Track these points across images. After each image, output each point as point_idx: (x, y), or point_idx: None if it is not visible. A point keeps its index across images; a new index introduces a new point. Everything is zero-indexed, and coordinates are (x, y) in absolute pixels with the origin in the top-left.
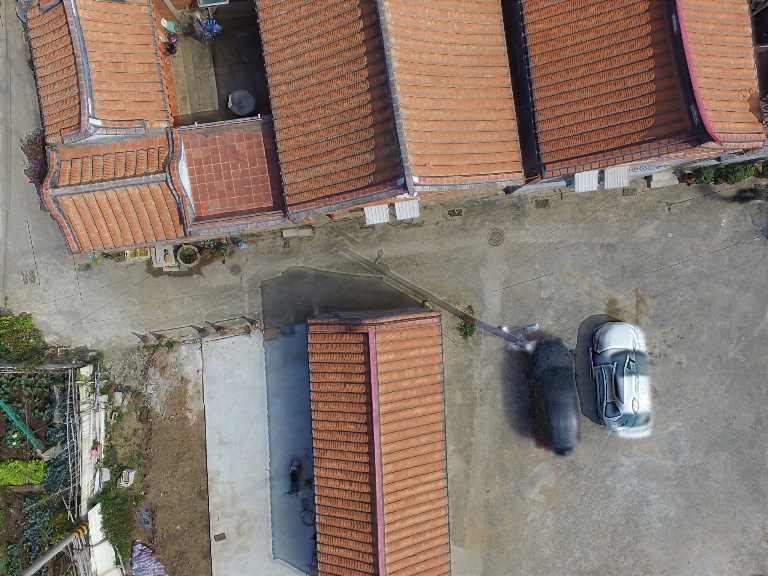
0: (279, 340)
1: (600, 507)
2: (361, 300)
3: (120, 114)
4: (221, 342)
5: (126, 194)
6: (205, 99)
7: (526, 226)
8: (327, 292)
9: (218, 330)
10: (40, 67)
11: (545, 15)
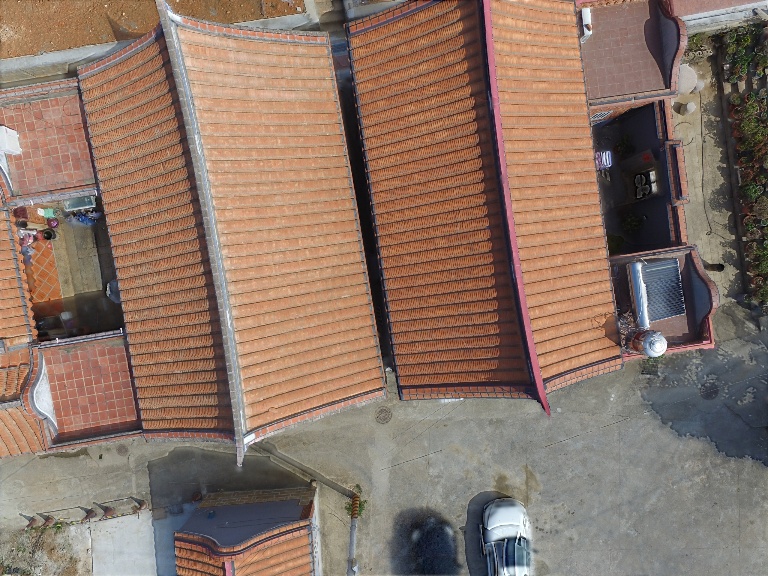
0: (168, 519)
1: None
2: (249, 479)
3: None
4: (110, 522)
5: None
6: (89, 279)
7: (413, 403)
8: (215, 471)
9: (103, 515)
10: None
11: (397, 241)
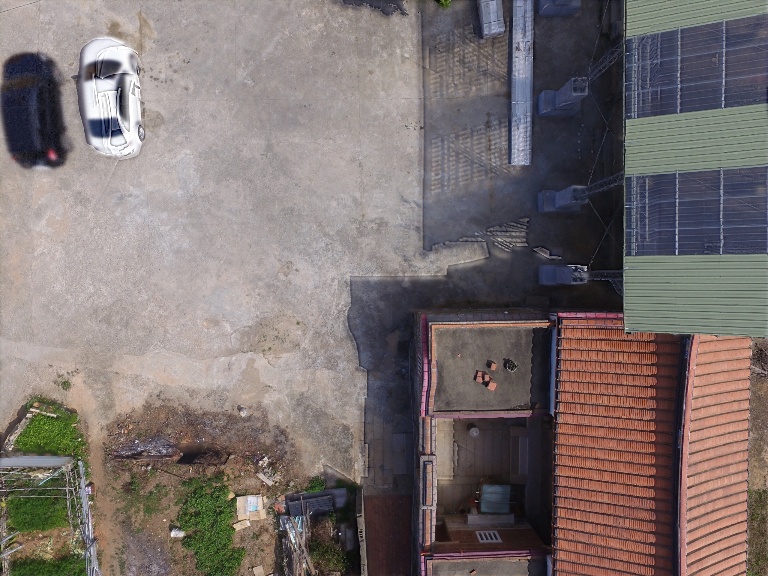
0: None
1: (111, 240)
2: None
3: None
4: None
5: None
6: None
7: None
8: None
9: None
10: None
11: None
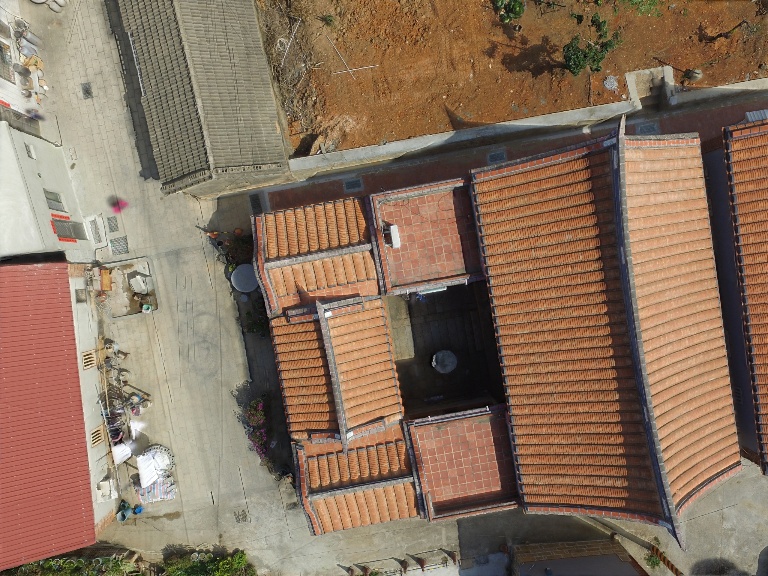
0: (474, 568)
1: None
2: (552, 532)
3: (365, 417)
4: (420, 571)
5: (371, 490)
6: (402, 348)
7: None
8: (520, 525)
9: (422, 567)
10: (285, 370)
11: None
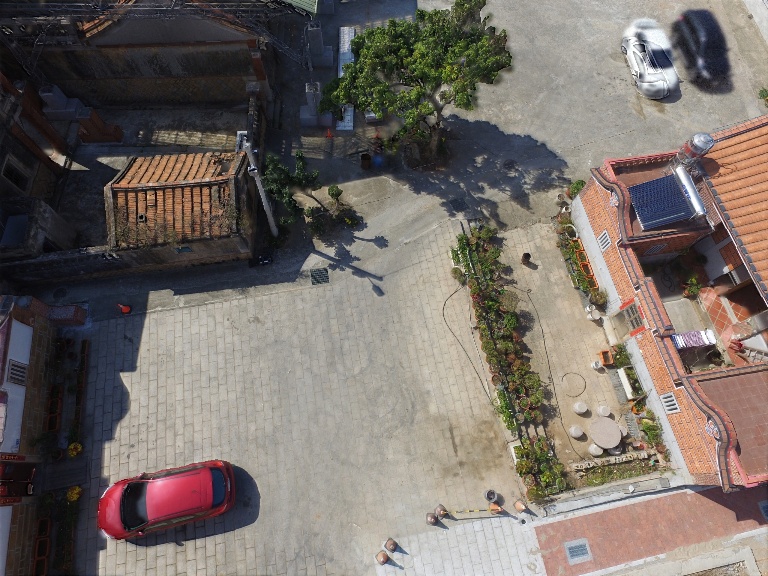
0: None
1: None
2: None
3: None
4: None
5: None
6: None
7: None
8: None
9: None
10: None
11: None
